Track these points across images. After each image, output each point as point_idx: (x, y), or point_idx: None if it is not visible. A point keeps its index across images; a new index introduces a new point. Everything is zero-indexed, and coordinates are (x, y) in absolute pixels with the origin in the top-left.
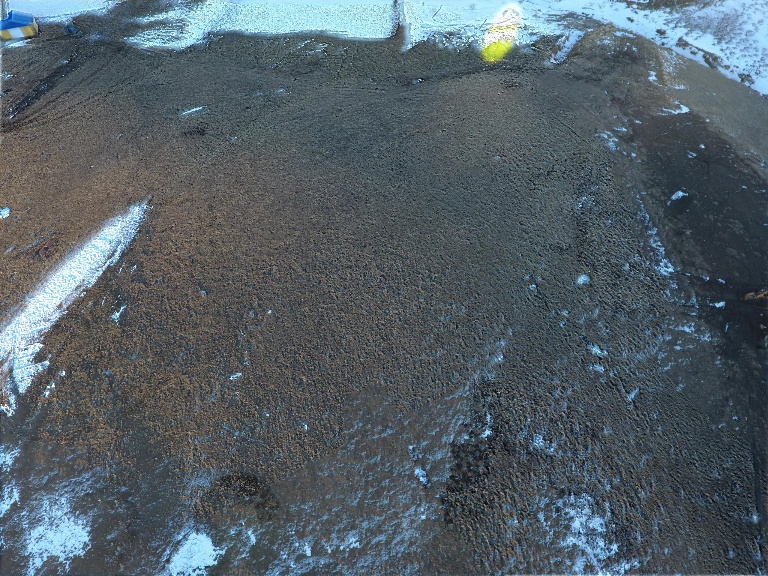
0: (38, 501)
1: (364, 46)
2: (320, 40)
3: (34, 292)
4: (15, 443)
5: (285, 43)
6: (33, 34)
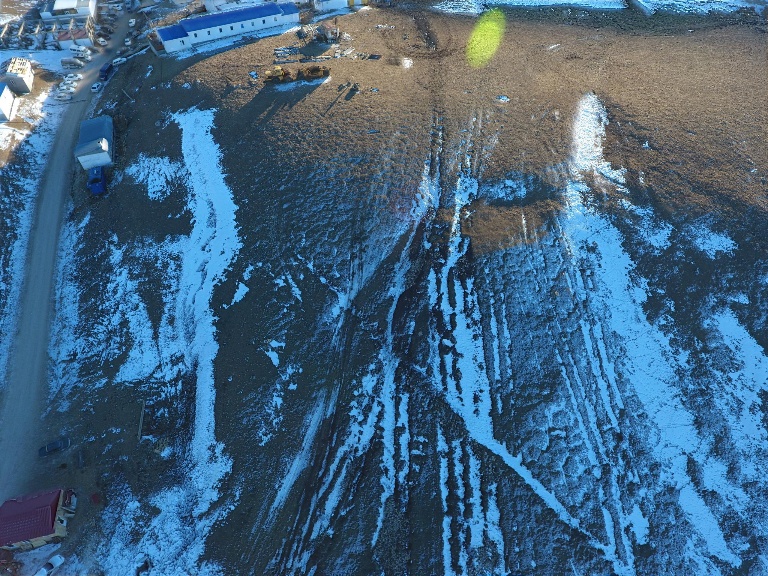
0: (688, 228)
1: (616, 13)
2: (578, 9)
3: (575, 137)
4: (646, 204)
5: (554, 11)
6: (367, 2)
